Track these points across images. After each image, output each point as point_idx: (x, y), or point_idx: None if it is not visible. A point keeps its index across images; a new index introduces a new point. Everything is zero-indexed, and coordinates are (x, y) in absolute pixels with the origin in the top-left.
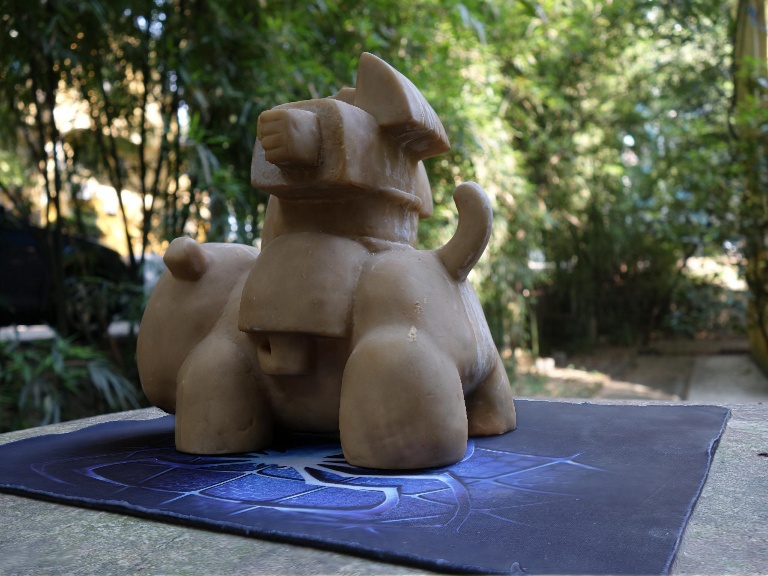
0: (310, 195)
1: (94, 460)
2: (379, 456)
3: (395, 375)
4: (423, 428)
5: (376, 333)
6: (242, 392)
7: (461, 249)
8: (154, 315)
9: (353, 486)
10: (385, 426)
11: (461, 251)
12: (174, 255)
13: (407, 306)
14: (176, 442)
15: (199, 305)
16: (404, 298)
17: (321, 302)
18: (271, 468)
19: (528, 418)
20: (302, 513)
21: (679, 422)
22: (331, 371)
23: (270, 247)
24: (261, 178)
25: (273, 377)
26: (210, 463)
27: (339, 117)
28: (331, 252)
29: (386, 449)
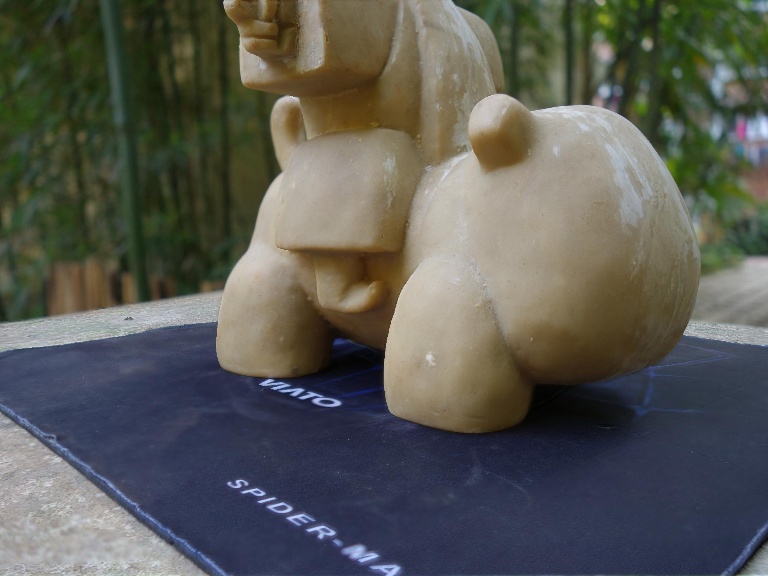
0: None
1: (676, 357)
2: None
3: None
4: None
5: None
6: None
7: None
8: None
9: None
10: None
11: None
12: None
13: None
14: None
15: None
16: None
17: None
18: None
19: (173, 371)
20: None
21: None
22: None
23: None
24: None
25: None
26: None
27: None
28: None
29: None
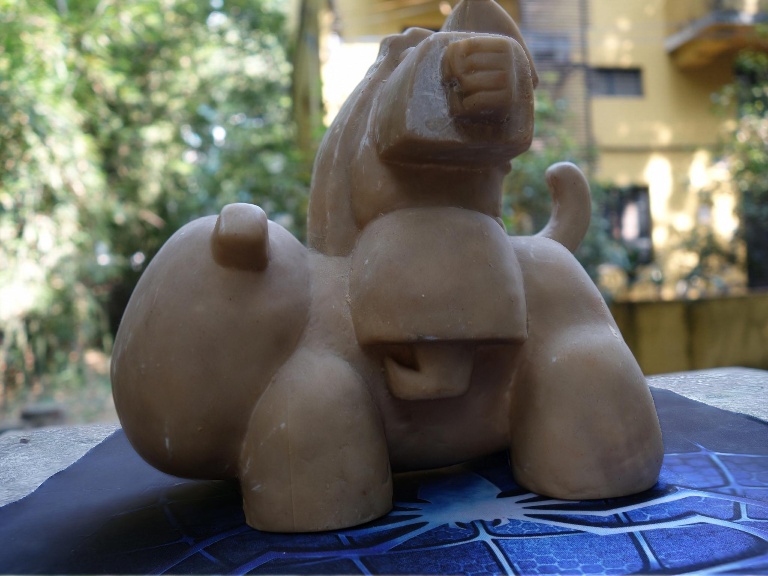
0: (460, 159)
1: None
2: (616, 482)
3: (626, 383)
4: (656, 441)
5: (575, 335)
6: (377, 429)
7: (573, 236)
8: (196, 326)
9: (657, 524)
10: (626, 445)
11: (573, 239)
12: (247, 231)
13: (595, 301)
14: (276, 520)
15: (278, 308)
16: (589, 292)
17: (516, 299)
18: (491, 526)
19: None
20: (739, 572)
21: (660, 403)
22: (486, 387)
23: (418, 225)
24: (423, 128)
25: (396, 403)
26: (387, 539)
27: (527, 63)
28: (501, 235)
29: (626, 472)
